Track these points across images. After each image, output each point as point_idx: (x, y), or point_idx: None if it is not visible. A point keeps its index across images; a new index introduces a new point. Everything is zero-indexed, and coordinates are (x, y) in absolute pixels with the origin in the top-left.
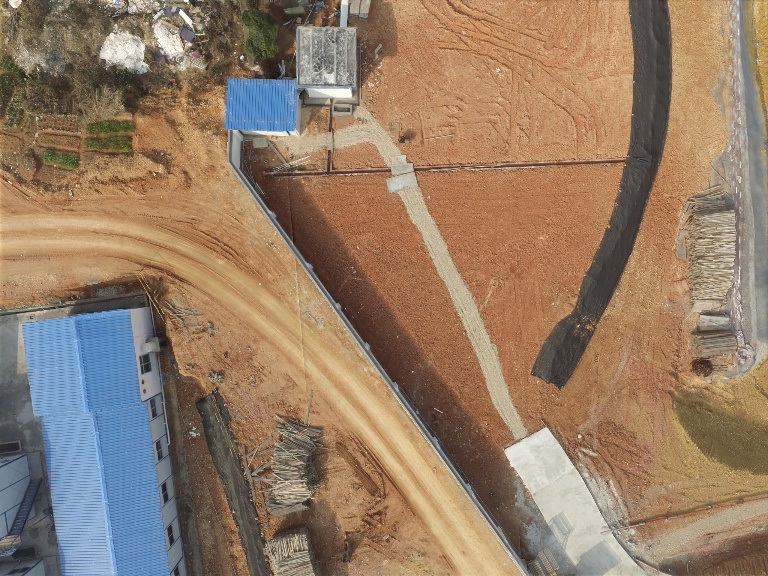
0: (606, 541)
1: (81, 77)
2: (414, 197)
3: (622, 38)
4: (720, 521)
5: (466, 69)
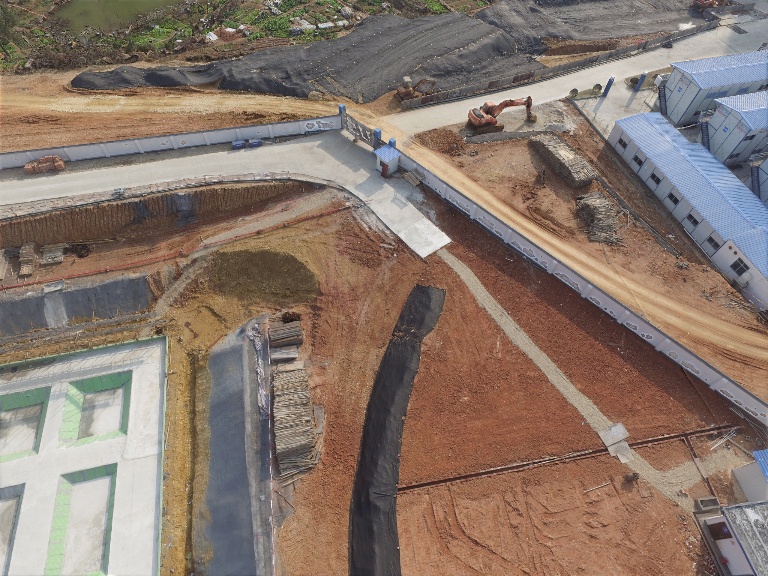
0: (367, 197)
1: None
2: (597, 421)
3: None
4: (276, 219)
5: None
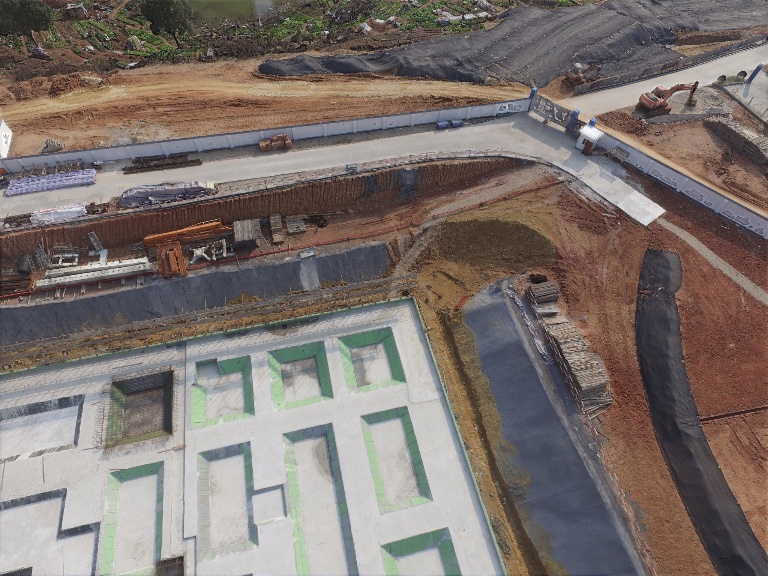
0: (576, 172)
1: None
2: None
3: None
4: (494, 192)
5: None
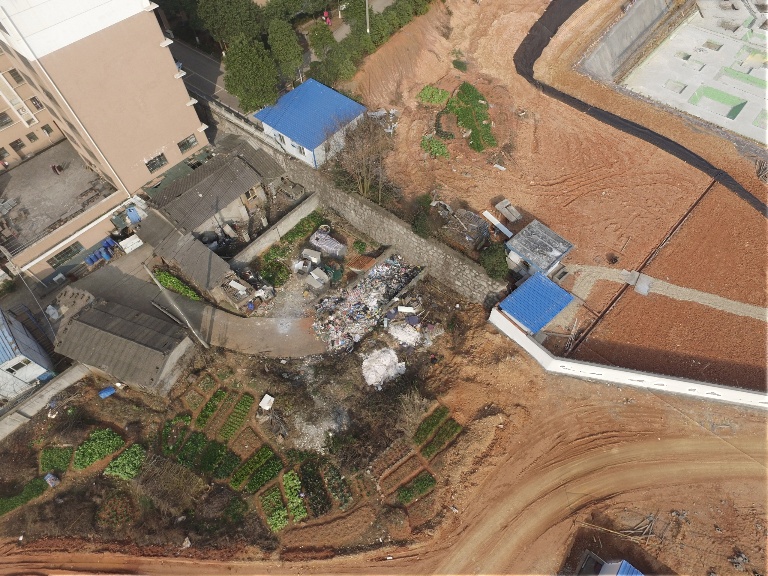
0: None
1: (371, 409)
2: (661, 286)
3: (632, 140)
4: None
5: (590, 205)
